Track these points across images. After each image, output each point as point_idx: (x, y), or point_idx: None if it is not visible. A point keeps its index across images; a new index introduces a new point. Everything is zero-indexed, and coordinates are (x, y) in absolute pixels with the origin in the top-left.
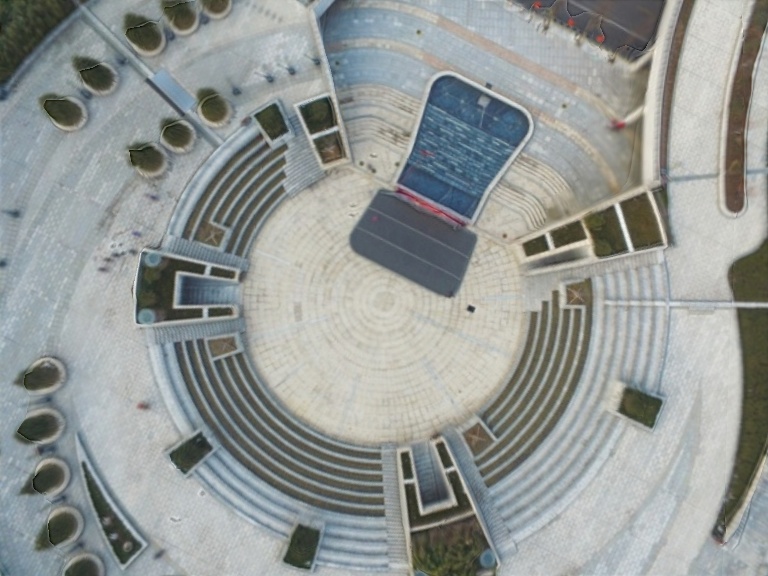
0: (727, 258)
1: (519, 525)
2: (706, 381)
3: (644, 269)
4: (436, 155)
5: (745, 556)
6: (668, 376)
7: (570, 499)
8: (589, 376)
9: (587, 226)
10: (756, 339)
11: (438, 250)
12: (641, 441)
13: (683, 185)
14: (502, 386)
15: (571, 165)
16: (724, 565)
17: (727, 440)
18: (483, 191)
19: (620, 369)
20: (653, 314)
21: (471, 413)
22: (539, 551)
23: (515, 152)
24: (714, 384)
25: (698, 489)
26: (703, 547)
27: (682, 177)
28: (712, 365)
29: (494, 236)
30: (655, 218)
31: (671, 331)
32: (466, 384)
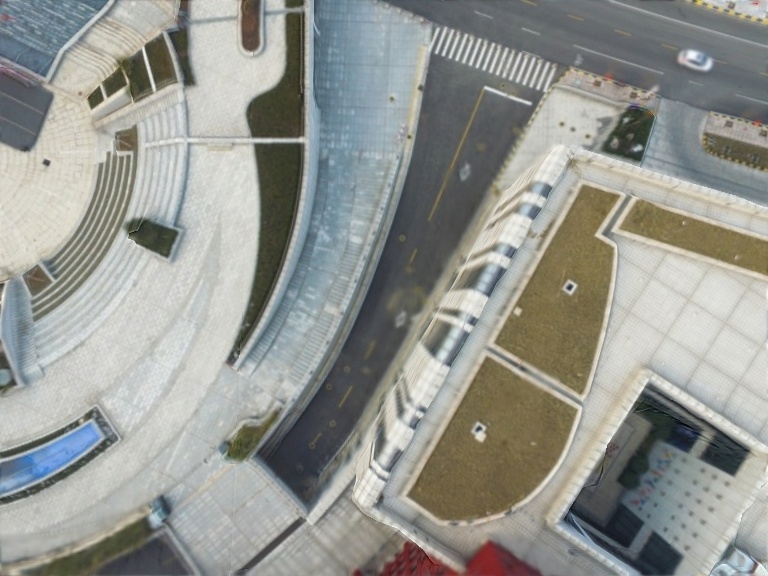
0: (246, 96)
1: (47, 351)
2: (225, 214)
3: (170, 109)
4: (18, 19)
5: (262, 381)
6: (188, 210)
7: (94, 326)
8: (131, 216)
9: (126, 72)
10: (271, 172)
11: (13, 106)
12: (162, 272)
13: (204, 27)
14: (72, 234)
15: (155, 28)
16: (240, 389)
17: (245, 270)
18: (58, 51)
19: (150, 206)
20: (177, 152)
21: (42, 259)
22: (64, 375)
23: (96, 15)
24: (233, 217)
25: (216, 317)
26: (219, 372)
27: (203, 19)
28: (231, 199)
29: (70, 94)
30: (170, 57)
31: (191, 166)
32: (40, 233)
